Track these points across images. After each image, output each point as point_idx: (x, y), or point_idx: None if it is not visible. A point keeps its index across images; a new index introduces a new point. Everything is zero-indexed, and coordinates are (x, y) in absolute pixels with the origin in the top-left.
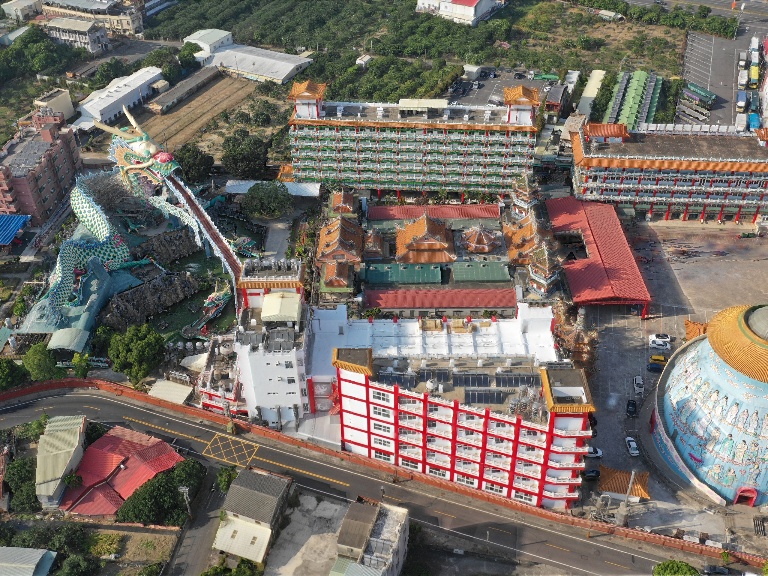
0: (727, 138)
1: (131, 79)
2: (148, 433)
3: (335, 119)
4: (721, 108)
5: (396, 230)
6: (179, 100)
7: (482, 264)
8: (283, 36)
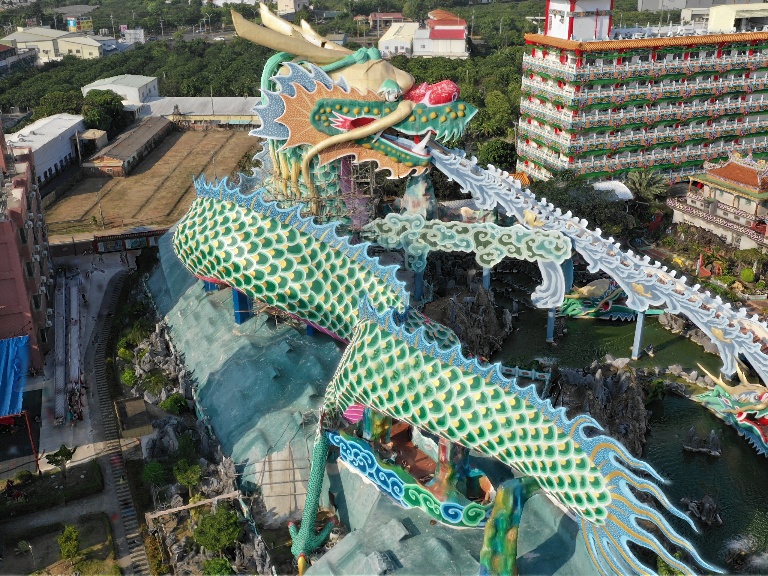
0: None
1: (37, 127)
2: None
3: None
4: None
5: None
6: (139, 156)
7: None
8: (232, 84)
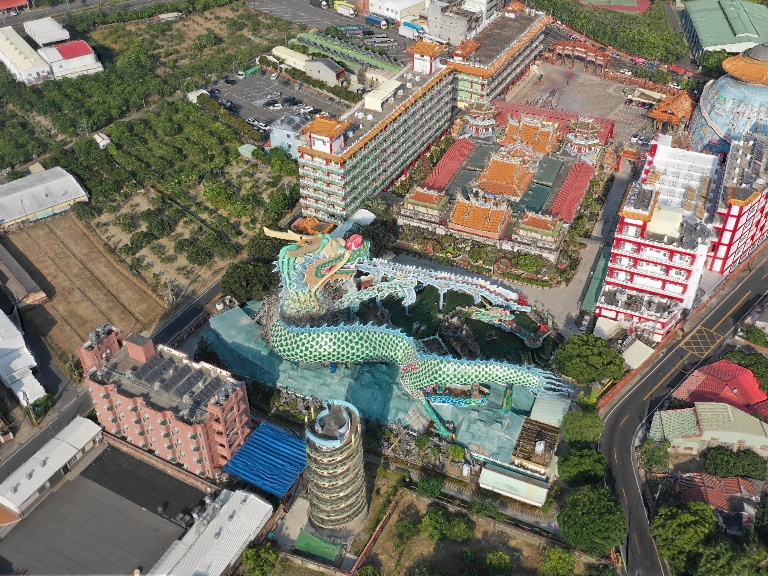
0: (496, 23)
1: None
2: (671, 386)
3: (362, 137)
4: (373, 32)
5: (474, 187)
6: None
7: (545, 164)
8: None
